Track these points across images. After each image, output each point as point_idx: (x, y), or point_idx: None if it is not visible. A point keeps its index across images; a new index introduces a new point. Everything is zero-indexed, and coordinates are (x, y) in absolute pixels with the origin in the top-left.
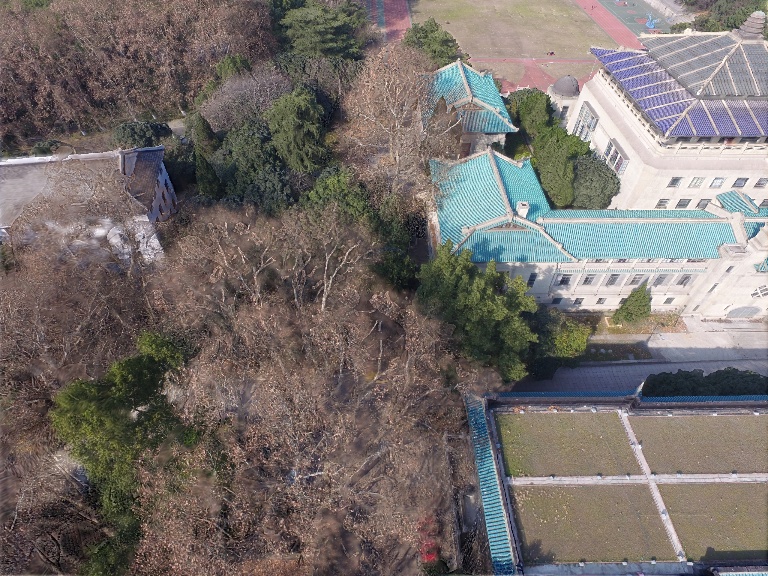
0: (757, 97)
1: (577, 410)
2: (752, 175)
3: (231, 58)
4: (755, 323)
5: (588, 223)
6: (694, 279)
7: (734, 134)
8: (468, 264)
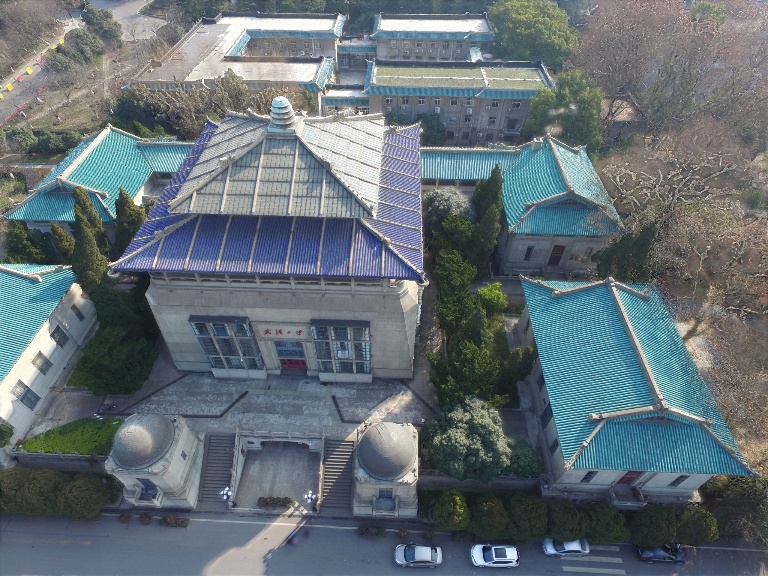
0: None
1: None
2: None
3: None
4: None
5: None
6: None
7: None
8: None
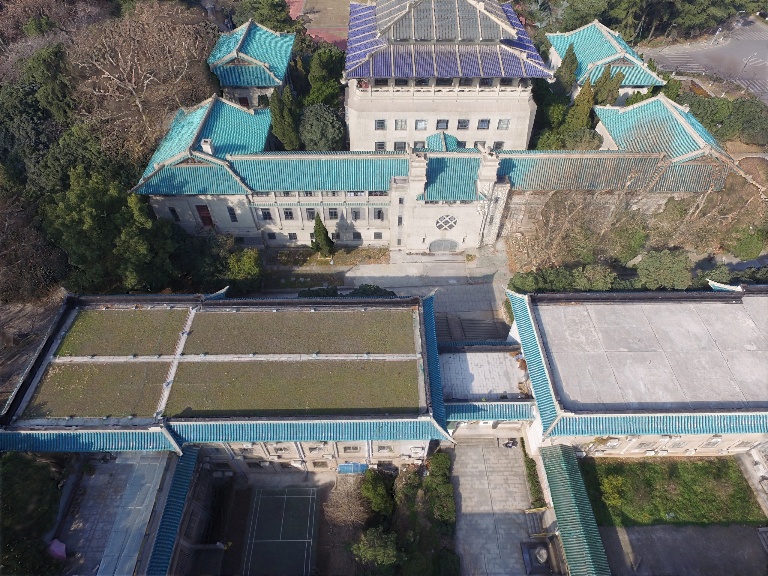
0: (445, 42)
1: (156, 308)
2: (449, 117)
3: (36, 20)
4: (456, 256)
5: (275, 160)
6: (387, 213)
7: (408, 75)
8: (99, 186)
